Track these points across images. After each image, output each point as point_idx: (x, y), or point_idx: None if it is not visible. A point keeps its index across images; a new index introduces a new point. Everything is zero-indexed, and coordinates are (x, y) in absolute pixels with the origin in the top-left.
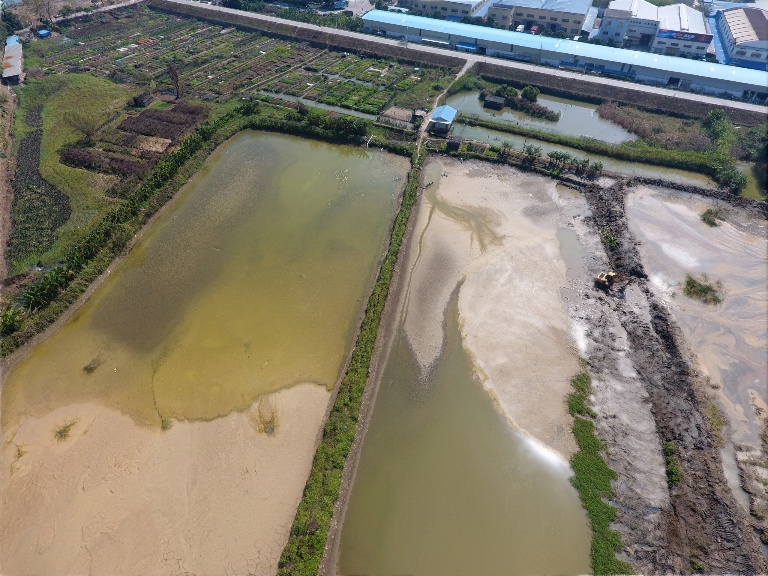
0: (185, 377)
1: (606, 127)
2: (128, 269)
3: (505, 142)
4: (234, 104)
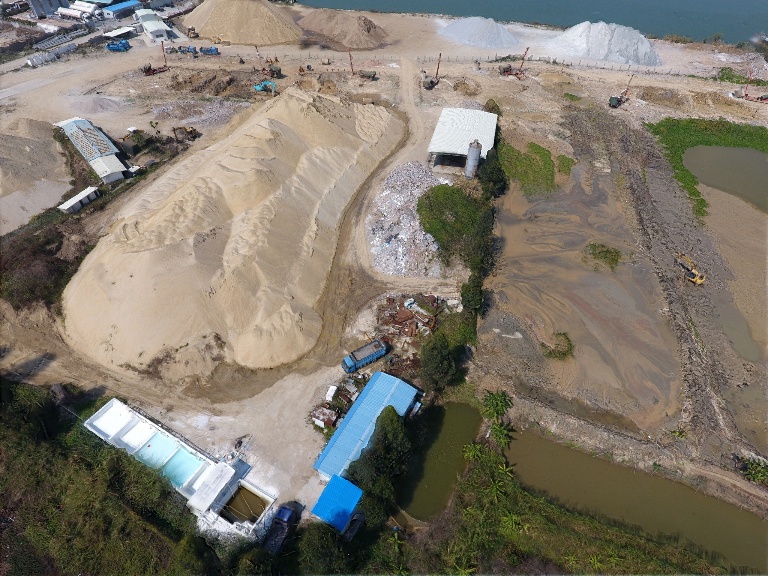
0: None
1: None
2: None
3: None
4: None
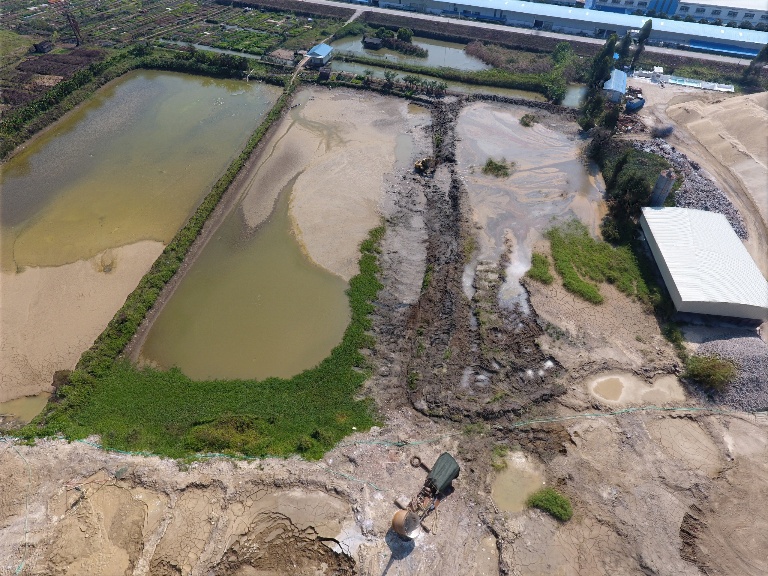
0: (43, 240)
1: None
2: (7, 171)
3: (367, 70)
4: None
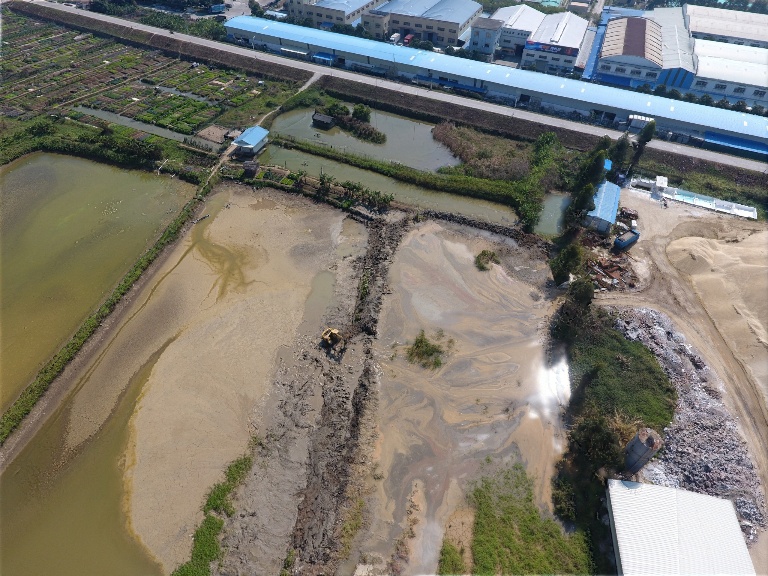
0: None
1: None
2: None
3: (300, 170)
4: None
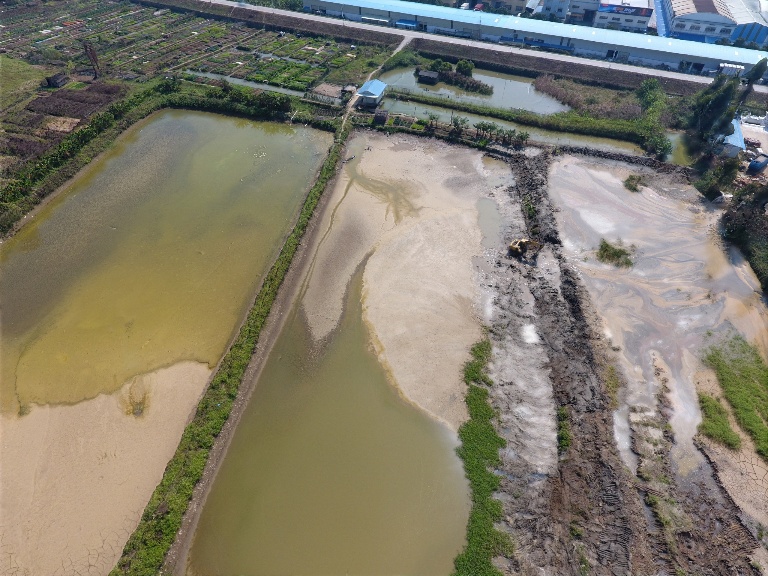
0: (54, 360)
1: (541, 100)
2: (11, 251)
3: (431, 114)
4: (156, 83)
